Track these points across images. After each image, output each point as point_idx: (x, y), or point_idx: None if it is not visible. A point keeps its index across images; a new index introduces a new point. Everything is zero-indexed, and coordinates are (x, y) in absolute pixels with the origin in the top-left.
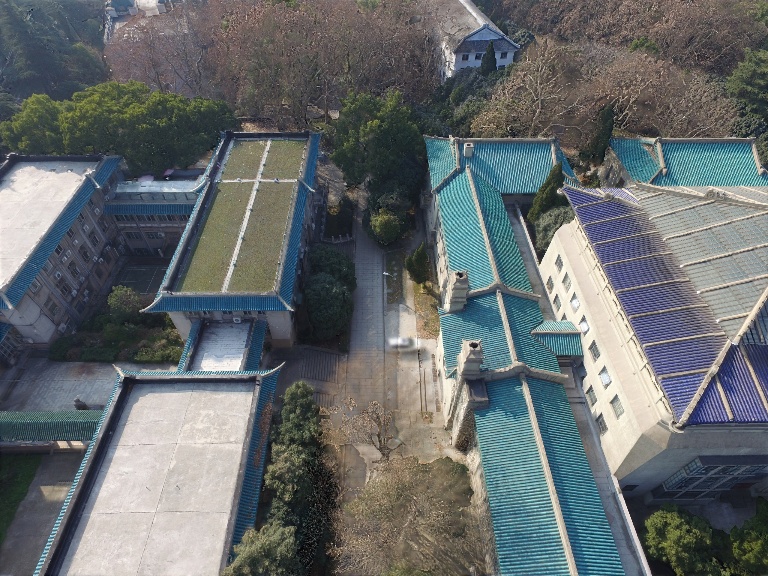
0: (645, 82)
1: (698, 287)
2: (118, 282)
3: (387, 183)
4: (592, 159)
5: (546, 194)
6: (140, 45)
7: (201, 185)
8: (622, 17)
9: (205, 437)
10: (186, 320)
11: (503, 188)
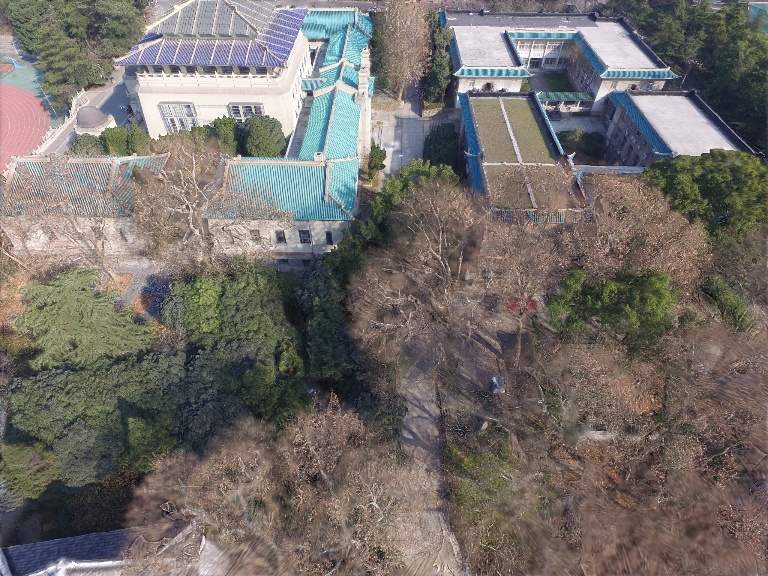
0: None
1: (274, 7)
2: None
3: None
4: None
5: None
6: None
7: None
8: None
9: (478, 60)
10: None
11: None
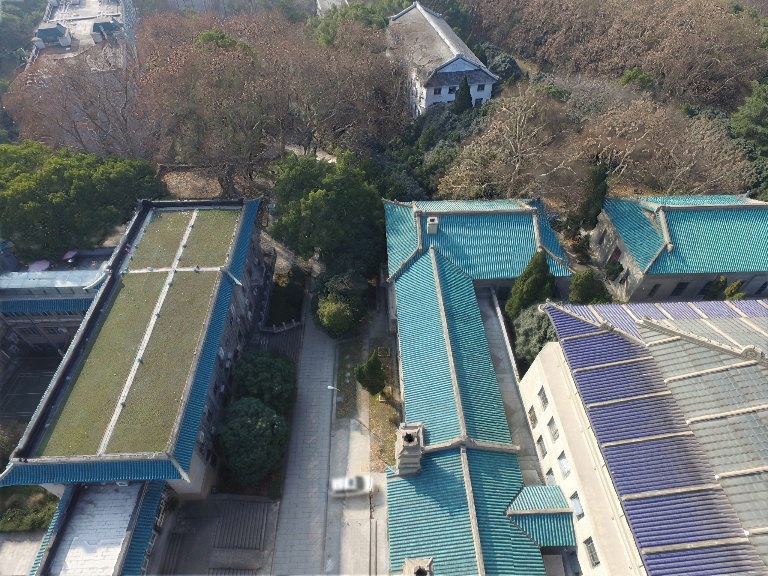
0: None
1: (745, 523)
2: (4, 396)
3: (339, 258)
4: (582, 225)
5: (527, 287)
6: (50, 91)
7: (100, 279)
8: (612, 42)
9: None
10: (55, 485)
11: (475, 273)
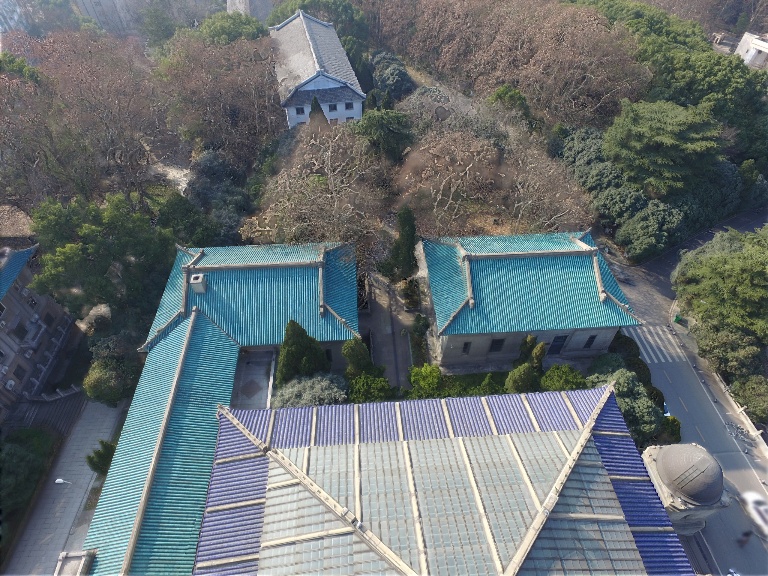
0: (499, 146)
1: None
2: None
3: (123, 314)
4: (398, 272)
5: (282, 360)
6: None
7: None
8: (496, 53)
9: None
10: None
11: (245, 338)
